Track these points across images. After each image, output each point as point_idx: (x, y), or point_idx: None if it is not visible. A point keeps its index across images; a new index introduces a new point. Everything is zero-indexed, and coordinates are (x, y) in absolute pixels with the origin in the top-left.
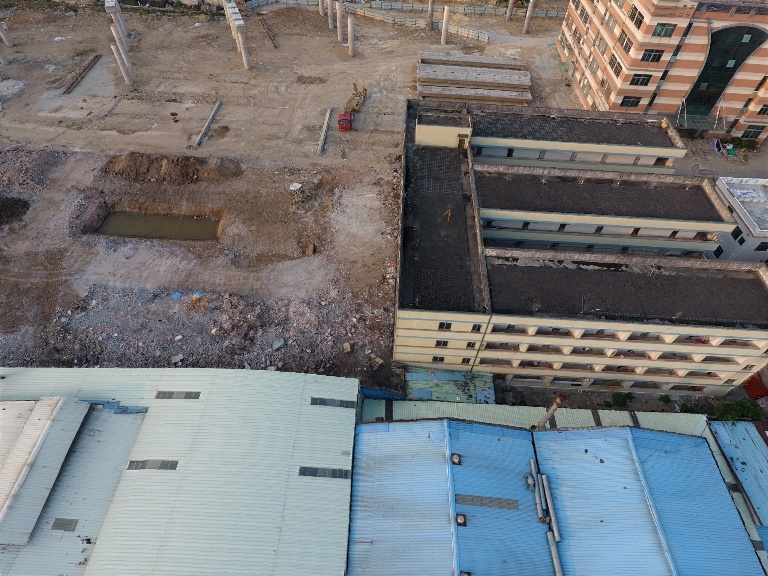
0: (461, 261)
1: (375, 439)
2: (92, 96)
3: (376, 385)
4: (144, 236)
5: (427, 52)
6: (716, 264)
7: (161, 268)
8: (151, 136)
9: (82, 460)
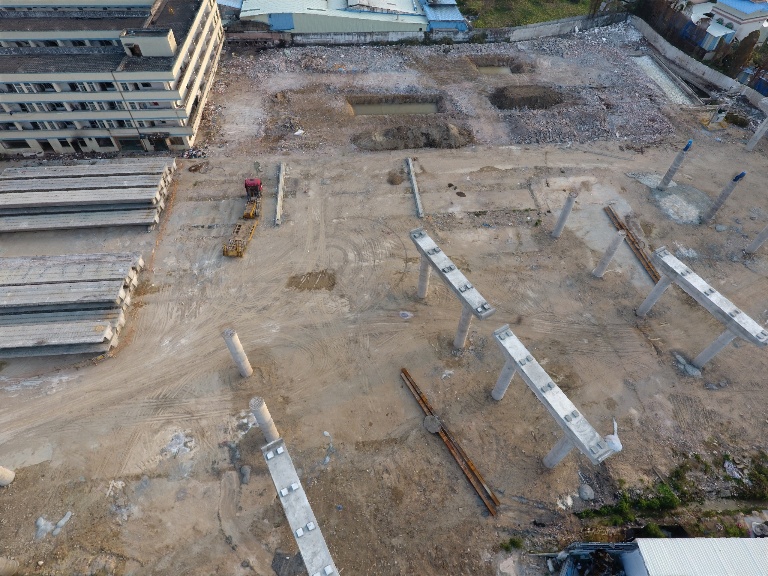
0: (173, 0)
1: (233, 4)
2: (575, 209)
3: (237, 50)
4: (401, 101)
5: (85, 340)
6: (20, 0)
7: (373, 80)
8: (461, 167)
9: (343, 0)
